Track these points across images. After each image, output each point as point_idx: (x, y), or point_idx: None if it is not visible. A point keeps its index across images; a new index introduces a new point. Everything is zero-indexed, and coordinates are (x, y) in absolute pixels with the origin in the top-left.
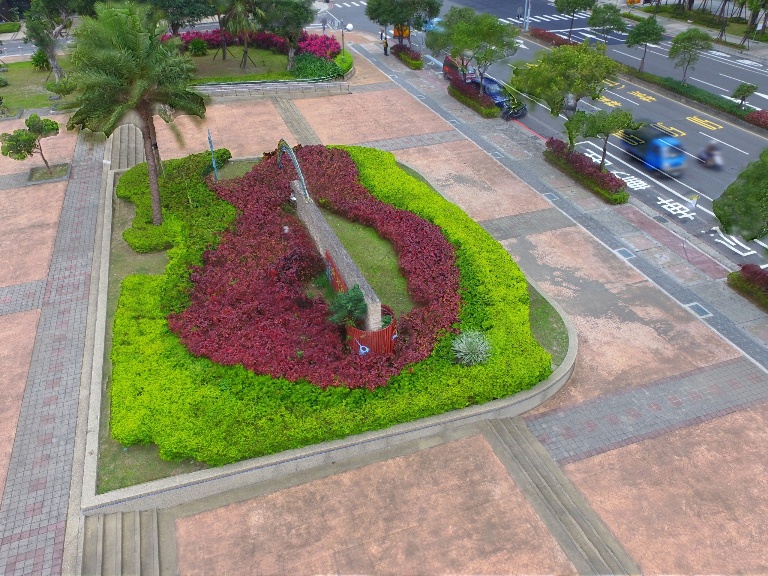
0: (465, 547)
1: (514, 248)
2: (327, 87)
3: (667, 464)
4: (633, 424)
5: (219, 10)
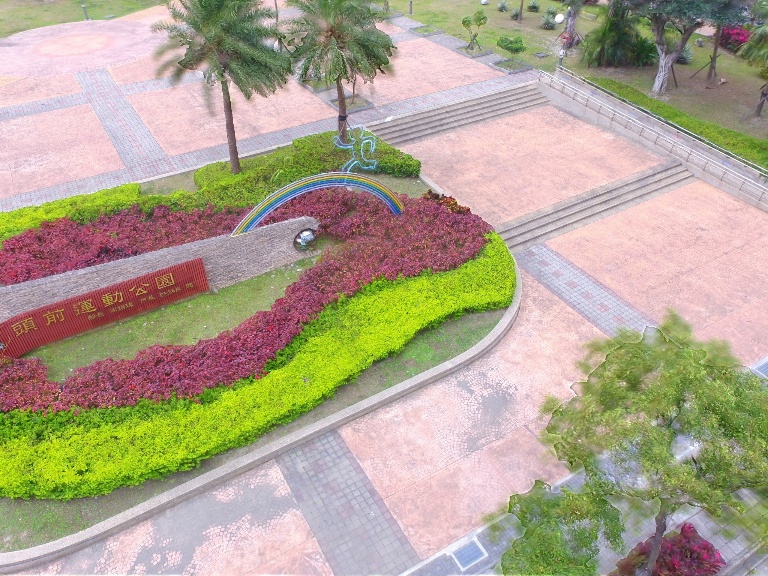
0: None
1: (257, 491)
2: (762, 193)
3: None
4: None
5: (763, 23)
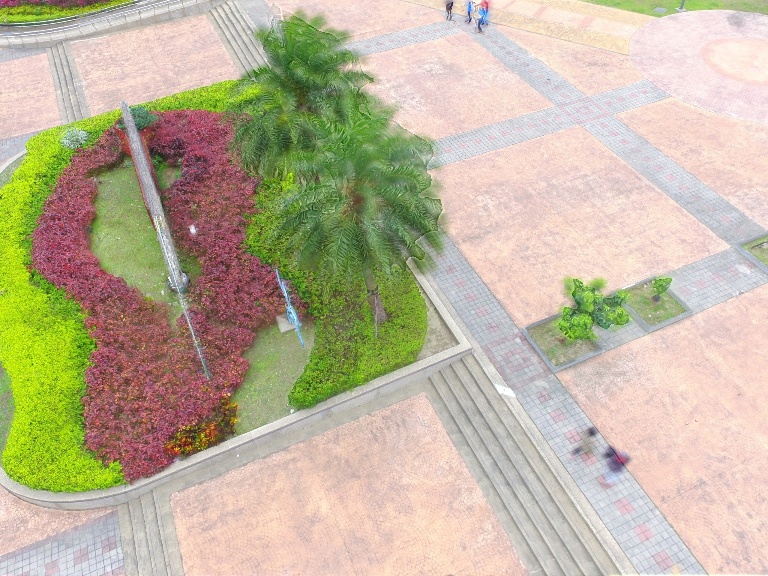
0: (125, 90)
1: None
2: None
3: (7, 129)
4: (5, 144)
5: None
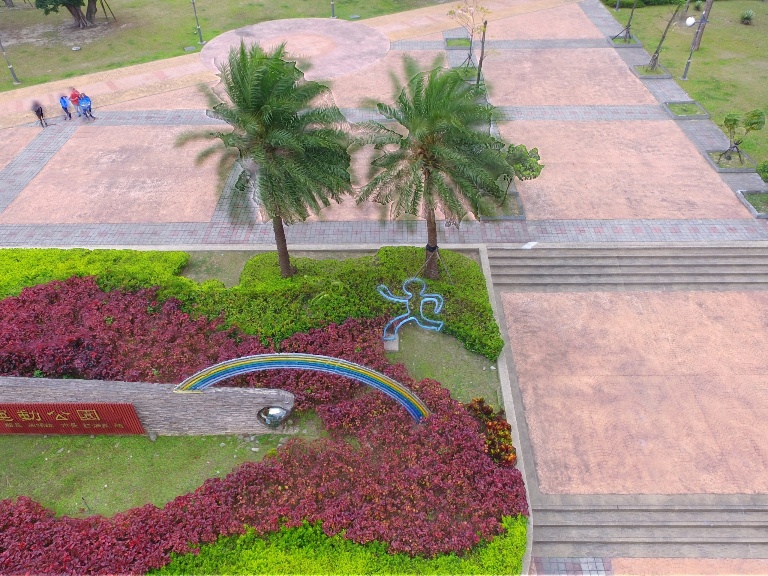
0: None
1: None
2: None
3: None
4: None
5: None
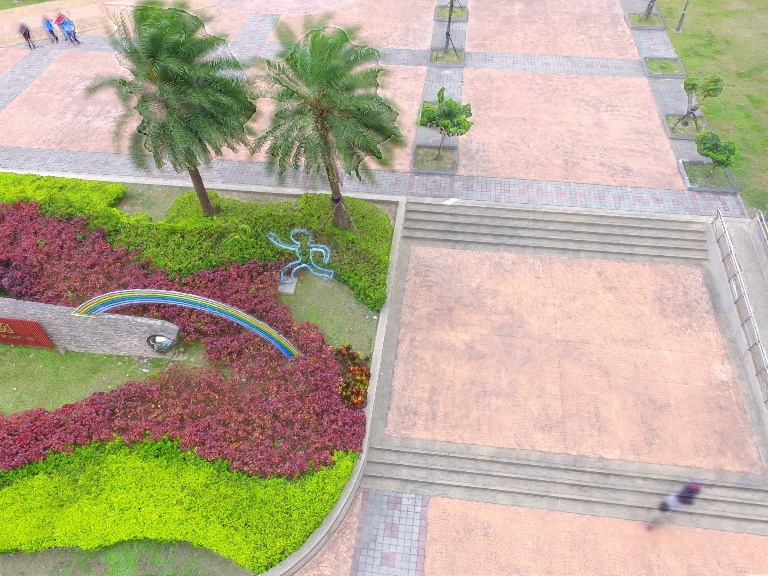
0: None
1: None
2: None
3: None
4: None
5: None
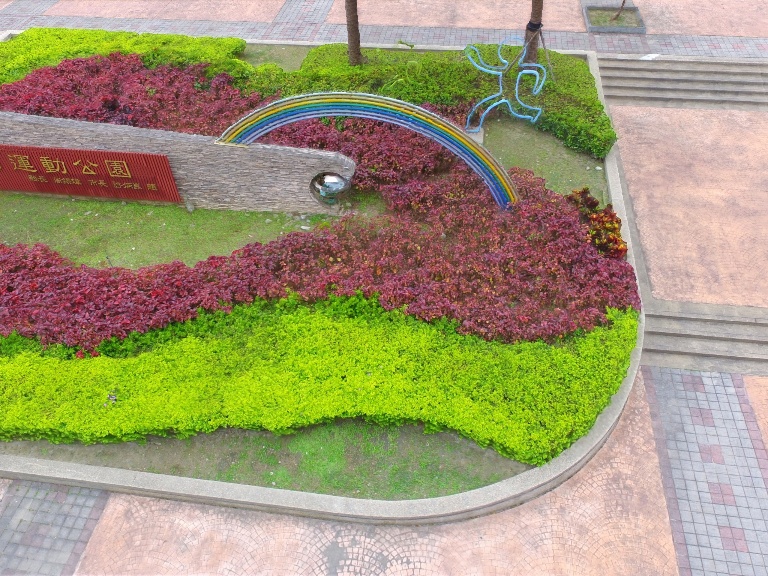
0: None
1: None
2: None
3: None
4: None
5: None
